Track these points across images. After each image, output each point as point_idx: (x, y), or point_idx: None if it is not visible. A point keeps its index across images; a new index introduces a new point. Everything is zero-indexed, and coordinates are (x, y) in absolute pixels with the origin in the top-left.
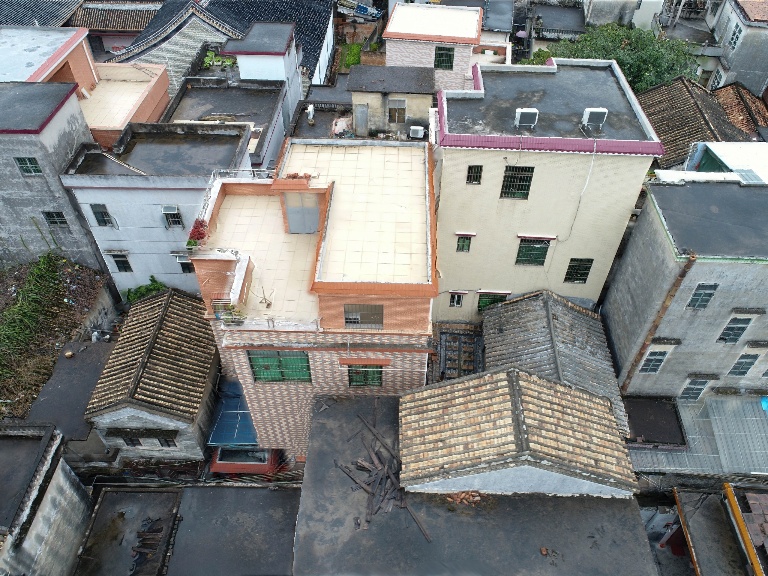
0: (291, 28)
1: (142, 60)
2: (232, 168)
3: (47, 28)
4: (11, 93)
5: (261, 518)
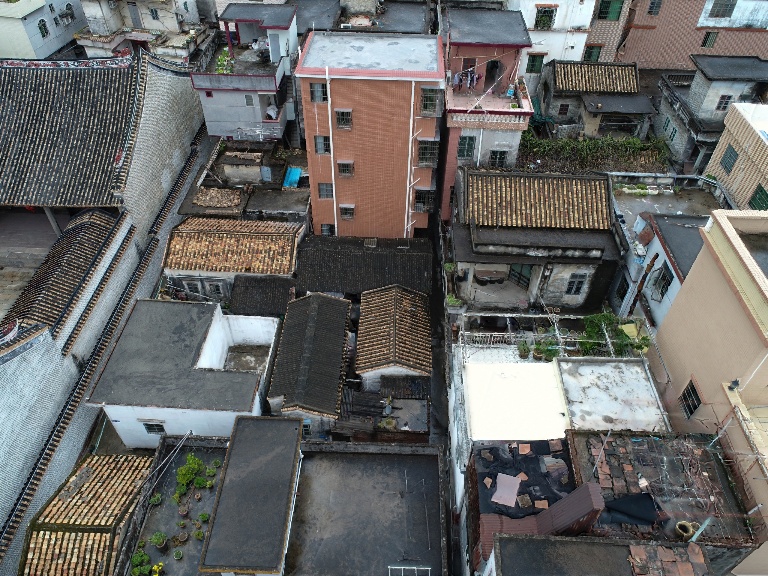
0: (243, 4)
1: (136, 153)
2: (493, 1)
3: (309, 47)
4: (468, 27)
5: (640, 79)
